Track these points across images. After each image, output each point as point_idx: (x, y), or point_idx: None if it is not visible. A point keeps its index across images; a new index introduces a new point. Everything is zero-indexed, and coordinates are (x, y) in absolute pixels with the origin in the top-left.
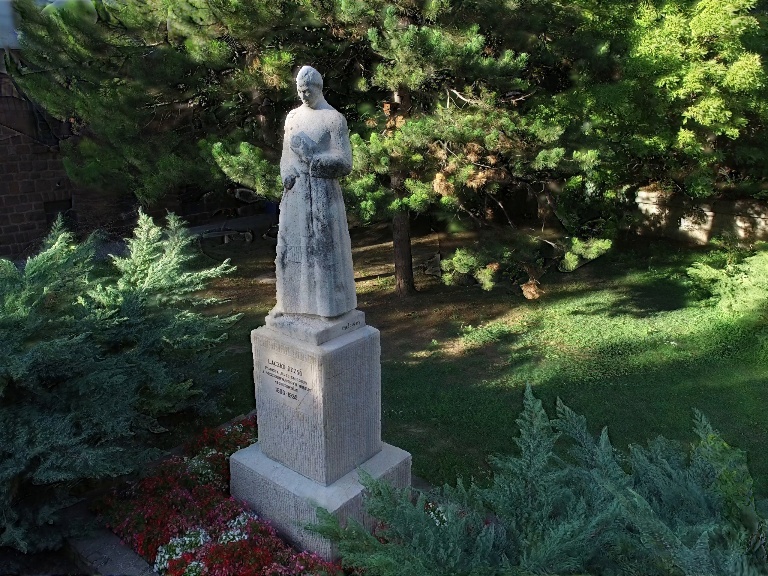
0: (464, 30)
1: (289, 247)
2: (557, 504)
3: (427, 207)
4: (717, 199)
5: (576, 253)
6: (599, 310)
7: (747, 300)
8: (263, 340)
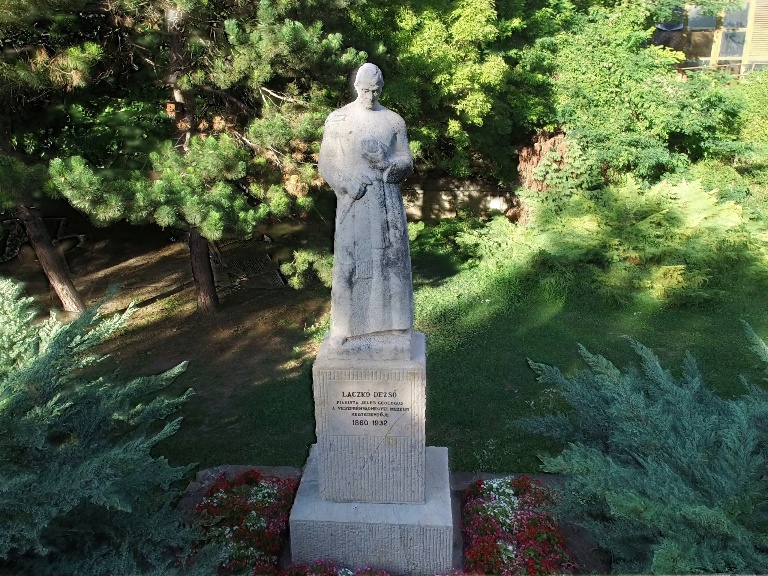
0: (306, 26)
1: (359, 263)
2: None
3: (289, 211)
4: (425, 179)
5: None
6: None
7: (520, 255)
8: (335, 373)
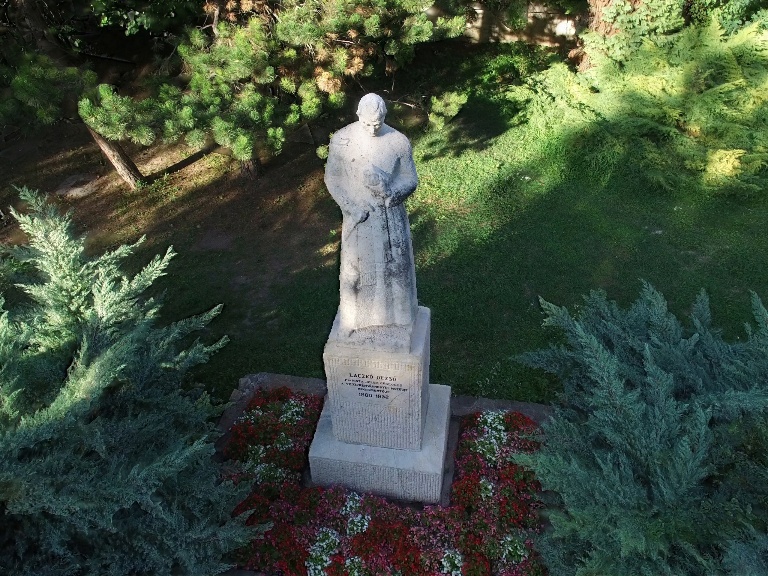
0: None
1: (362, 274)
2: (643, 418)
3: (320, 111)
4: None
5: (437, 112)
6: (443, 150)
7: (569, 123)
8: (342, 360)
